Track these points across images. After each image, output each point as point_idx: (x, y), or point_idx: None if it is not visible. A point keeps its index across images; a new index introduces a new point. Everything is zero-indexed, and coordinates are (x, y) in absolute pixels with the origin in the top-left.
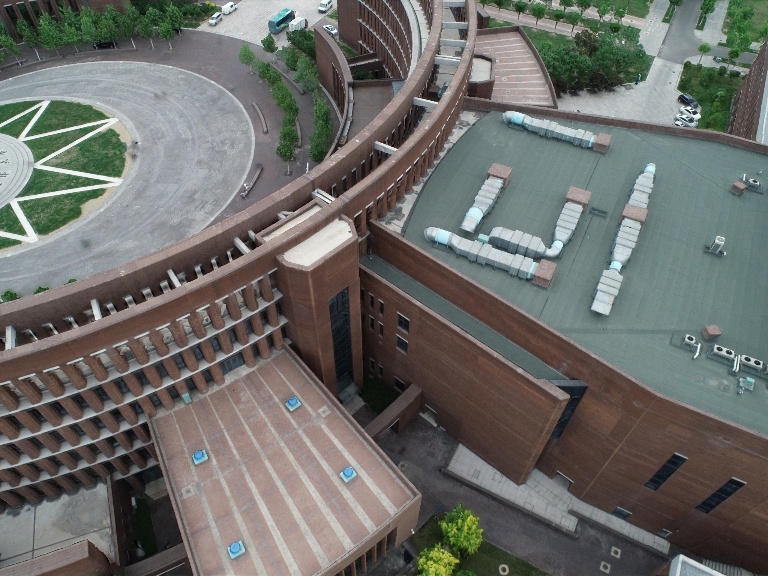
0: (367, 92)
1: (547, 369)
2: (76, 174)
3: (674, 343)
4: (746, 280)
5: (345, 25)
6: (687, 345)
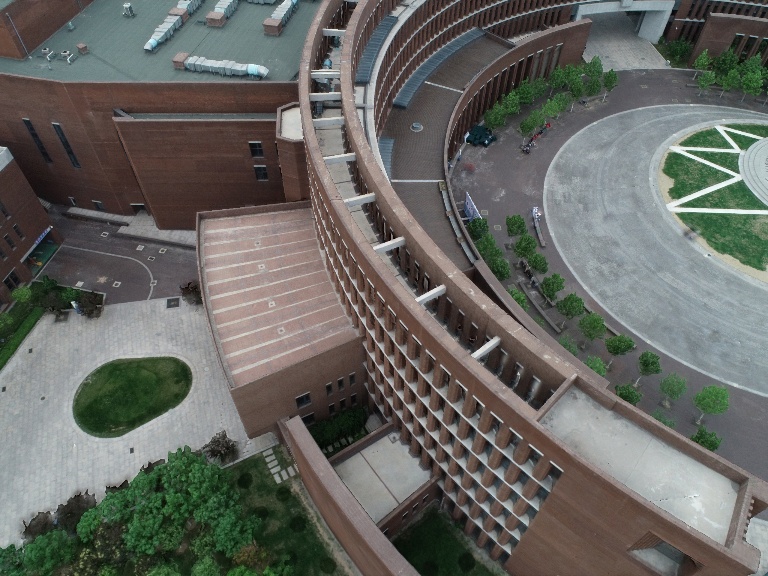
0: None
1: None
2: (722, 210)
3: None
4: (118, 7)
5: None
6: None
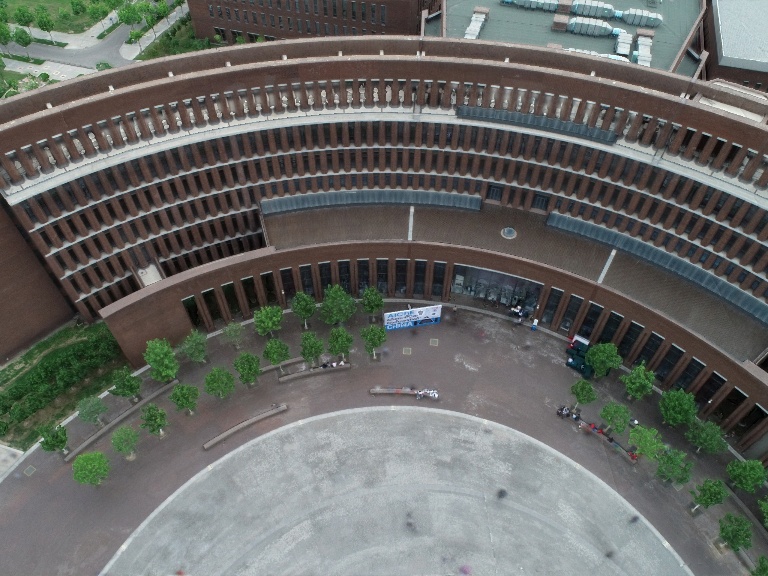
0: (283, 238)
1: (683, 63)
2: None
3: (656, 6)
4: None
5: (3, 333)
6: (655, 2)
